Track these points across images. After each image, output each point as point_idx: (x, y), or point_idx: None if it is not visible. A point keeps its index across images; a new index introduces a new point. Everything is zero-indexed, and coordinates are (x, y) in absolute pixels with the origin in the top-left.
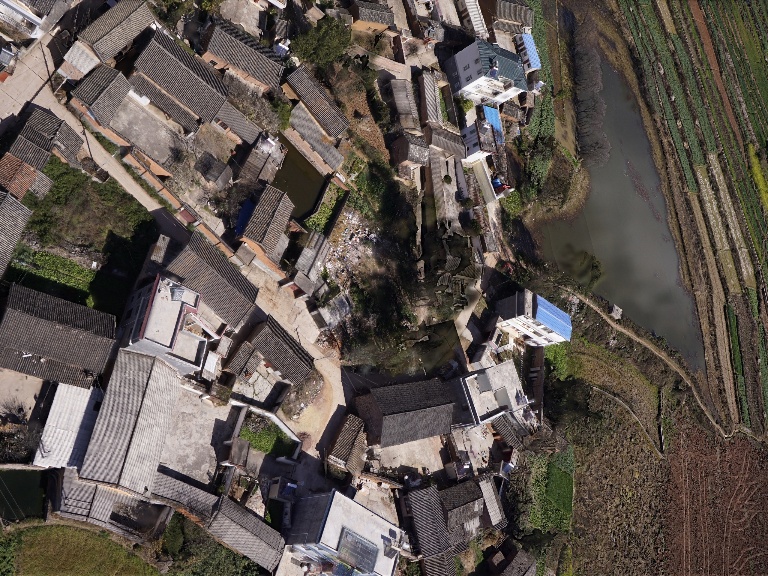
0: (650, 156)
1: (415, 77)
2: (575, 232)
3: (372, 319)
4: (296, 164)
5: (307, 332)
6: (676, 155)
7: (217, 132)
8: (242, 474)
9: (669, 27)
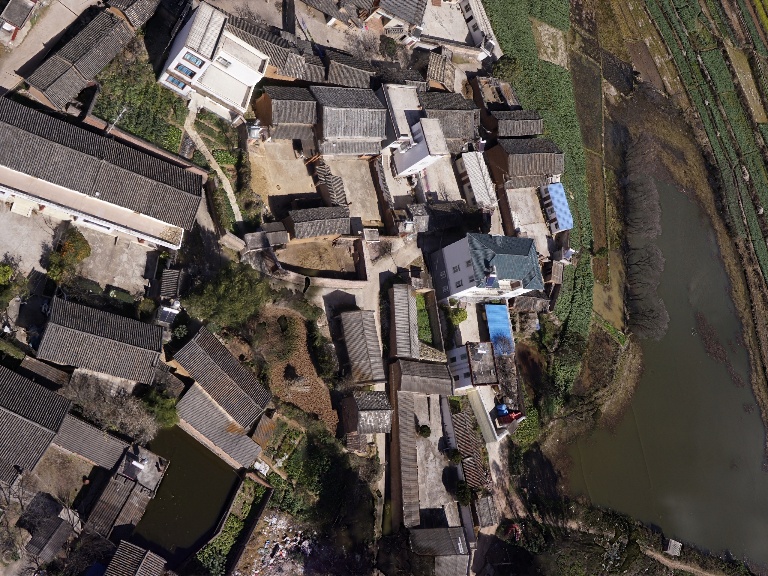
0: (729, 296)
1: (384, 289)
2: (618, 440)
3: None
4: (201, 451)
5: None
6: (764, 287)
7: (63, 455)
8: None
9: (758, 115)
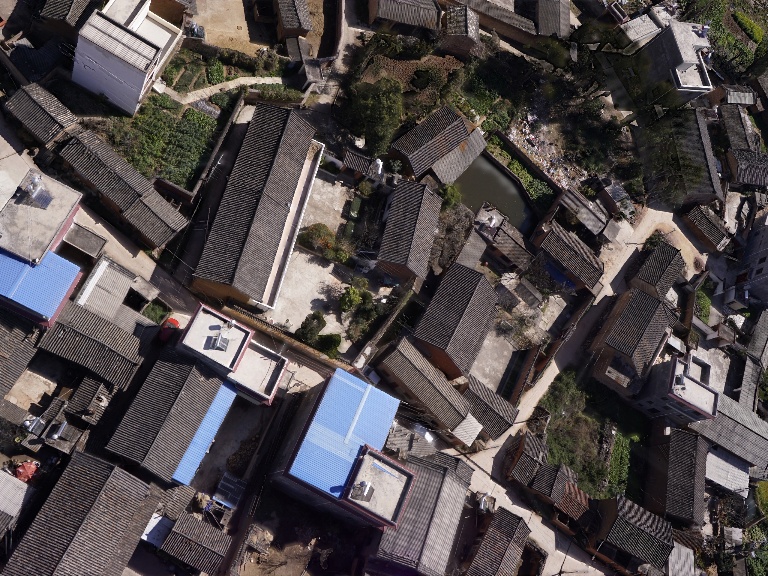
0: None
1: None
2: None
3: (612, 157)
4: None
5: (626, 233)
6: None
7: None
8: None
9: None
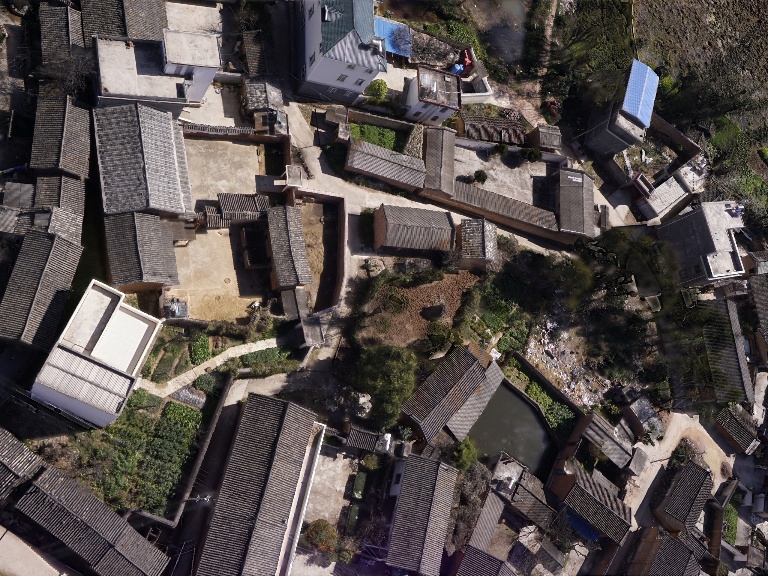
0: None
1: (343, 173)
2: None
3: (637, 361)
4: None
5: (651, 450)
6: None
7: None
8: (750, 543)
9: None
